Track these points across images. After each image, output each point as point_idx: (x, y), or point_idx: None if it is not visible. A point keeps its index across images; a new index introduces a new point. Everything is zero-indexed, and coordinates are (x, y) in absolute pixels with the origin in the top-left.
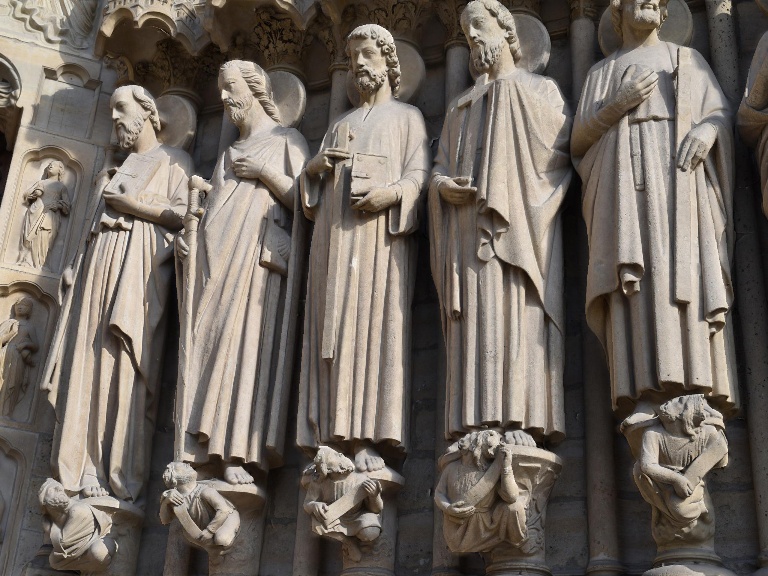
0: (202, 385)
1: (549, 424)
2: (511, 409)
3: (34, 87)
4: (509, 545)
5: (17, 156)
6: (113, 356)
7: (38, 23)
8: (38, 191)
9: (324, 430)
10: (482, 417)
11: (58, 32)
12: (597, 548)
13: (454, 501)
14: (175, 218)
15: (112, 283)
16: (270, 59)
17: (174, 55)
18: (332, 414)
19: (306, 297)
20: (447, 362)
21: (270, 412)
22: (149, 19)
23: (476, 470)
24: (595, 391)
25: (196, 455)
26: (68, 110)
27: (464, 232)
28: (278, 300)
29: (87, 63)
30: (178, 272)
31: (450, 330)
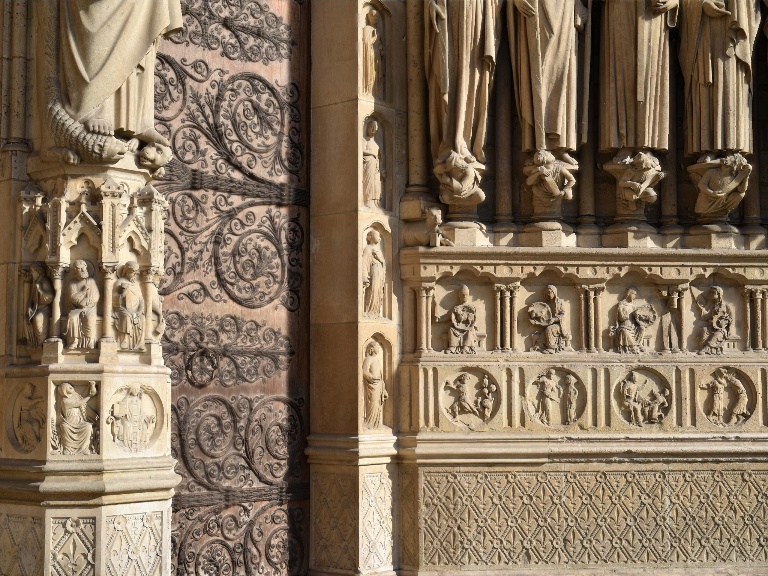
0: (550, 103)
1: (749, 150)
2: (741, 143)
3: None
4: (725, 210)
5: None
6: (479, 73)
7: None
8: None
9: (632, 141)
10: (727, 146)
11: None
12: (753, 211)
13: (716, 190)
14: None
15: (479, 24)
16: None
17: None
18: (640, 133)
19: (611, 55)
20: (695, 108)
21: (581, 121)
22: None
23: (731, 176)
24: (753, 128)
25: (547, 145)
26: None
27: (716, 35)
28: (578, 49)
29: None
30: (513, 19)
31: (696, 89)
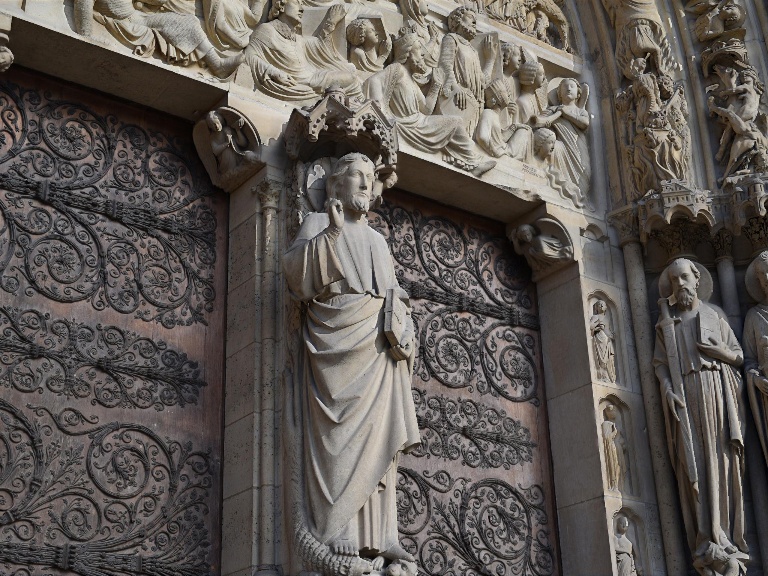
0: None
1: None
2: None
3: (579, 244)
4: None
5: (585, 299)
6: (728, 458)
7: (570, 193)
8: (603, 326)
9: None
10: None
11: (580, 199)
12: None
13: None
14: (740, 360)
15: (721, 408)
16: (761, 241)
17: (685, 230)
18: None
19: None
20: None
21: None
22: (698, 214)
23: None
24: None
25: None
26: (593, 259)
27: None
28: None
29: (599, 223)
30: (756, 400)
31: None
